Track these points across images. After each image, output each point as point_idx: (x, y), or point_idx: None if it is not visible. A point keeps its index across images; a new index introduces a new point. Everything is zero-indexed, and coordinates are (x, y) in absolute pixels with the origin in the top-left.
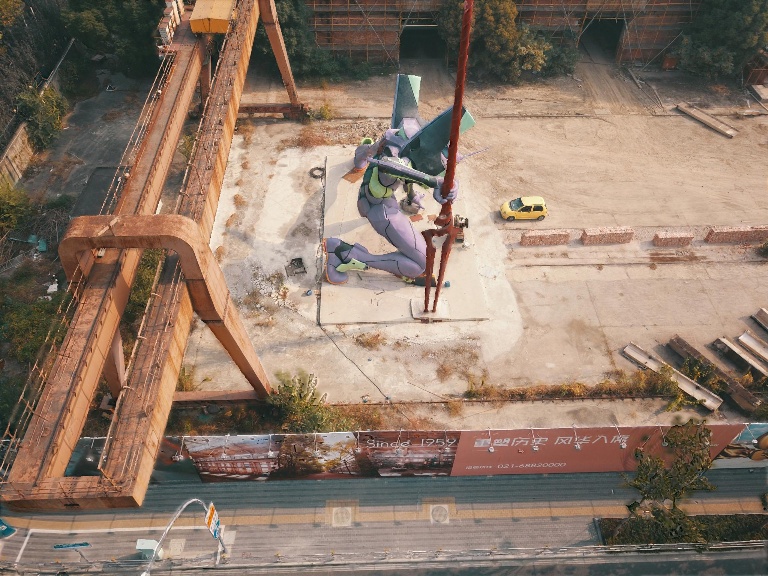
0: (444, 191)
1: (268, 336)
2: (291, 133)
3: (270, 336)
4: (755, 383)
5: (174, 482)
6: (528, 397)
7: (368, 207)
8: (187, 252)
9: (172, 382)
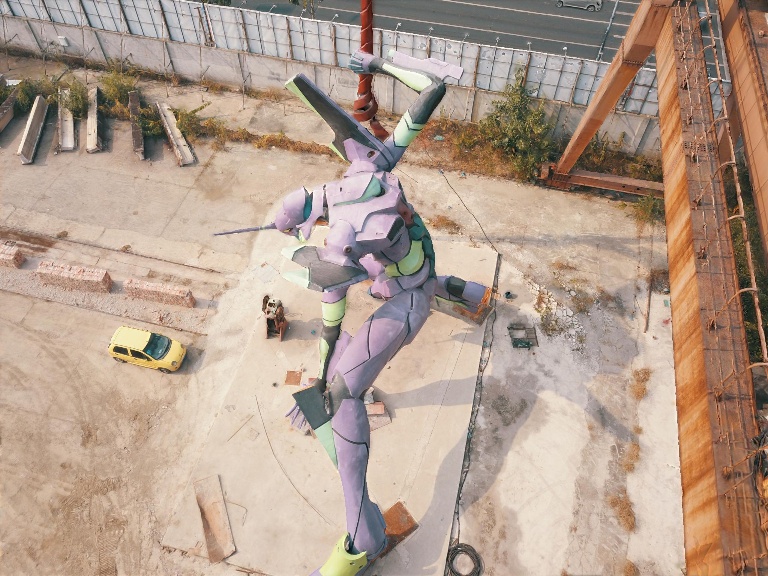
0: None
1: (559, 254)
2: None
3: (557, 253)
4: None
5: None
6: None
7: None
8: None
9: None
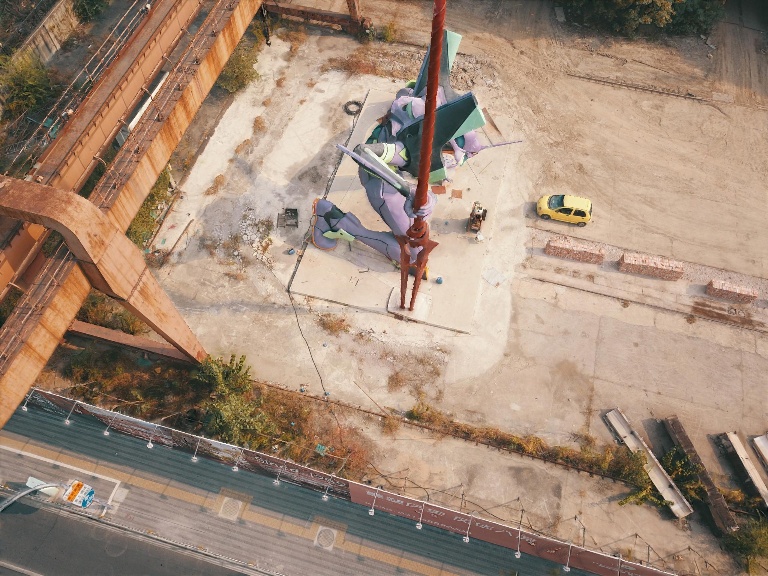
0: (415, 205)
1: (233, 290)
2: (343, 51)
3: (235, 290)
4: (745, 501)
5: (88, 424)
6: (473, 438)
7: (367, 178)
8: (71, 236)
9: (31, 371)
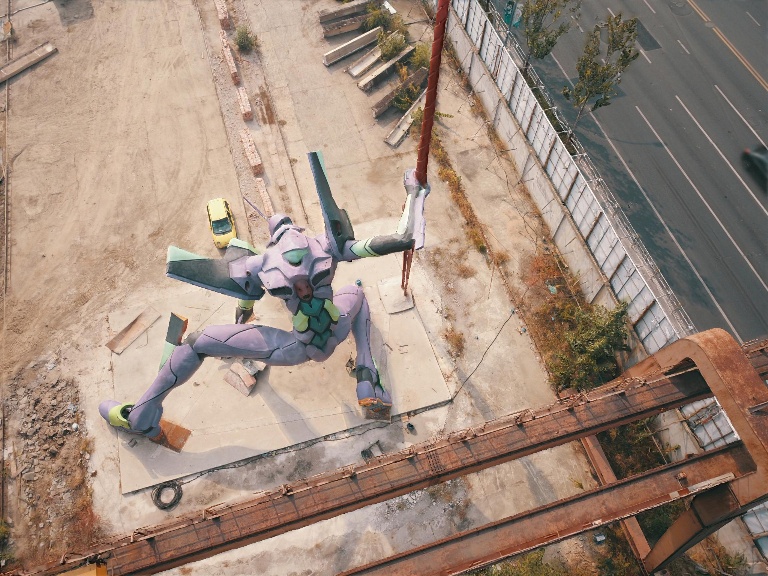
0: None
1: None
2: None
3: None
4: None
5: None
6: None
7: (333, 339)
8: None
9: None
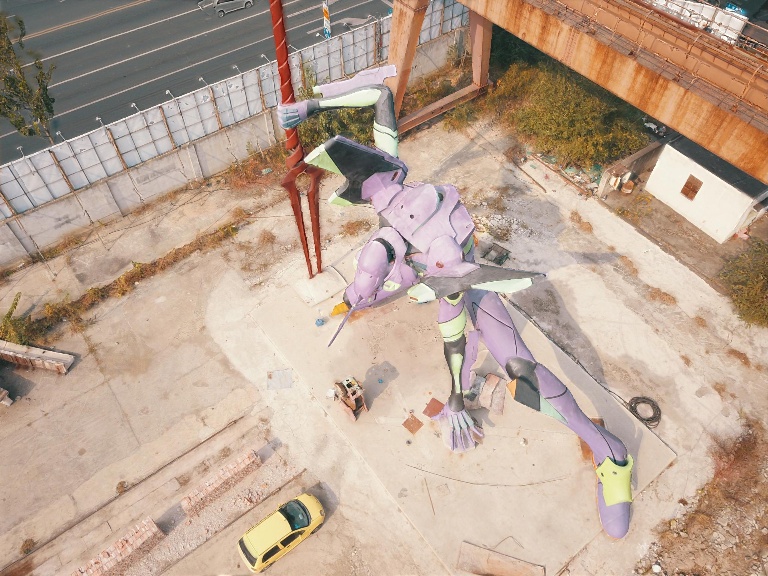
0: None
1: None
2: None
3: None
4: None
5: None
6: None
7: None
8: None
9: None
